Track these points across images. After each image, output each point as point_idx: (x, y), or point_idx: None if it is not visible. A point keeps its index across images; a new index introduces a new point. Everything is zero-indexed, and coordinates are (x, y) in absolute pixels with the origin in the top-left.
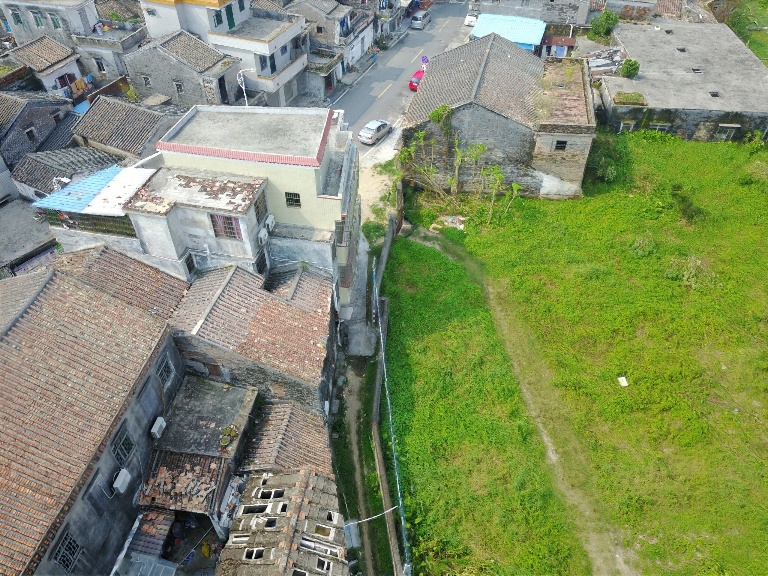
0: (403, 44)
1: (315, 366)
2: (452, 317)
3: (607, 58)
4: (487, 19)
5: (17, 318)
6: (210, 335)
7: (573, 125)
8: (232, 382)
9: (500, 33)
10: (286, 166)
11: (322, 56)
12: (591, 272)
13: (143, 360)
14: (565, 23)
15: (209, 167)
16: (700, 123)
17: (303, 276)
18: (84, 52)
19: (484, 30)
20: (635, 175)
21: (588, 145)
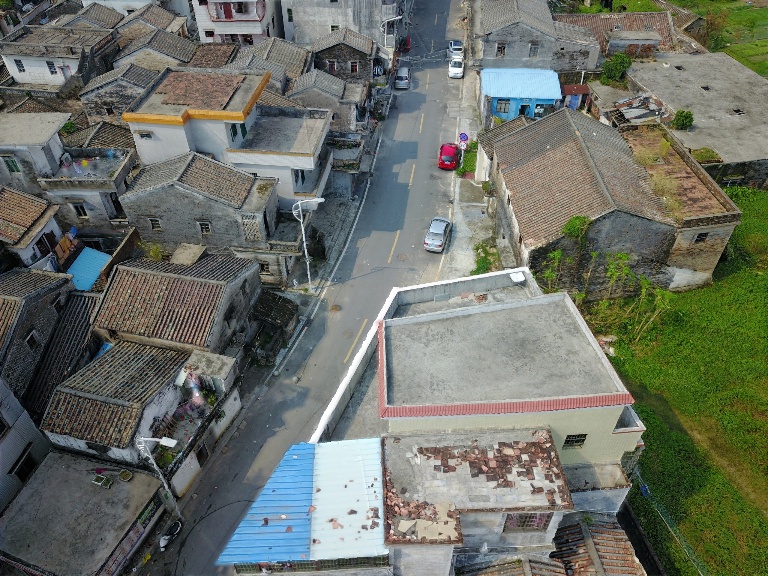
0: (398, 110)
1: None
2: (689, 493)
3: (641, 107)
4: (493, 74)
5: None
6: None
7: (719, 216)
8: None
9: (514, 90)
10: (584, 409)
11: (340, 147)
12: None
13: None
14: (575, 70)
15: (460, 425)
16: None
17: (593, 535)
18: (56, 197)
19: (495, 88)
20: (748, 246)
21: (730, 233)
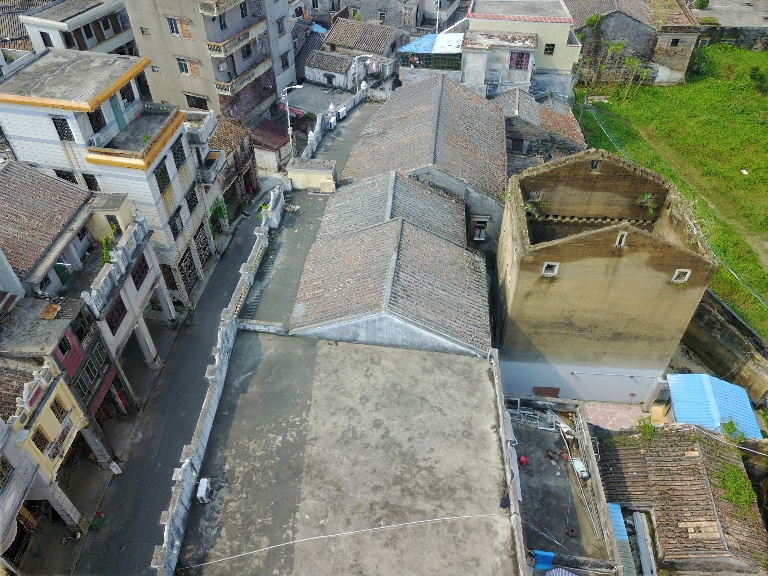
0: None
1: (581, 139)
2: (623, 144)
3: None
4: None
5: (441, 92)
6: (524, 117)
7: (685, 26)
8: (526, 154)
9: None
10: (552, 24)
11: None
12: (707, 120)
13: (501, 122)
14: None
15: (499, 29)
16: (758, 38)
17: (553, 99)
18: None
19: None
20: (719, 70)
21: (694, 42)
